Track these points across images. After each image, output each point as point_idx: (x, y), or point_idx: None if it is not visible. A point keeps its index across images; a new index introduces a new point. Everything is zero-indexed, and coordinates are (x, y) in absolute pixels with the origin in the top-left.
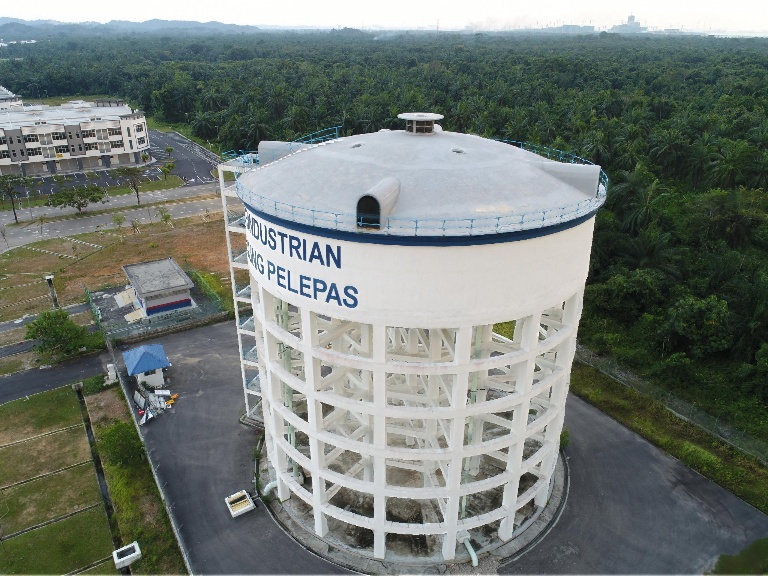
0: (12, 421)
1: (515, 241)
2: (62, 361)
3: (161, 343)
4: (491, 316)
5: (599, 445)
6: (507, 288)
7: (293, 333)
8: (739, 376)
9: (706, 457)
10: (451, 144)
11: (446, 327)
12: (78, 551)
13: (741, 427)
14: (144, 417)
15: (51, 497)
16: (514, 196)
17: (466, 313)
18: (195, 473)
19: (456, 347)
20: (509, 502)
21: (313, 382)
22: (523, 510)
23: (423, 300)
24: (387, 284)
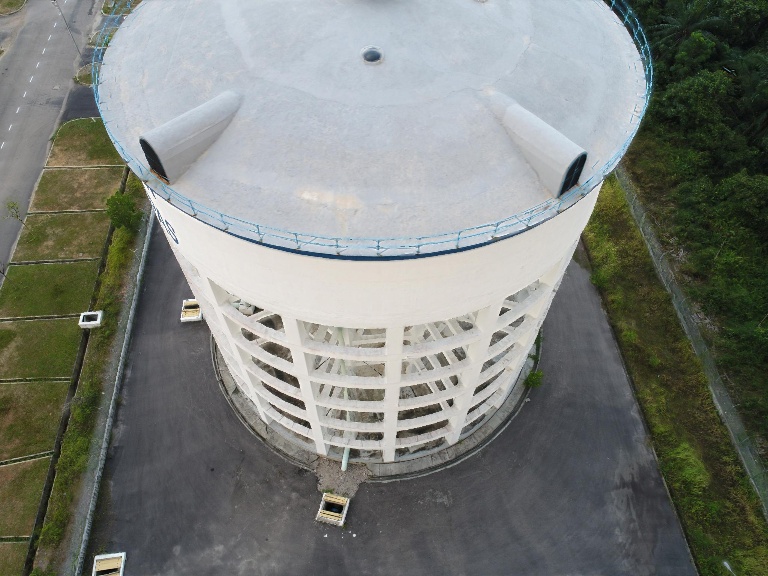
0: (74, 142)
1: (337, 259)
2: None
3: None
4: (318, 318)
5: (578, 399)
6: (338, 299)
7: None
8: None
9: (690, 474)
10: (383, 31)
11: (264, 308)
12: (63, 299)
13: None
14: None
15: (68, 236)
16: (383, 180)
17: (285, 306)
18: None
19: None
20: (385, 442)
21: None
22: None
23: (232, 275)
24: (194, 242)
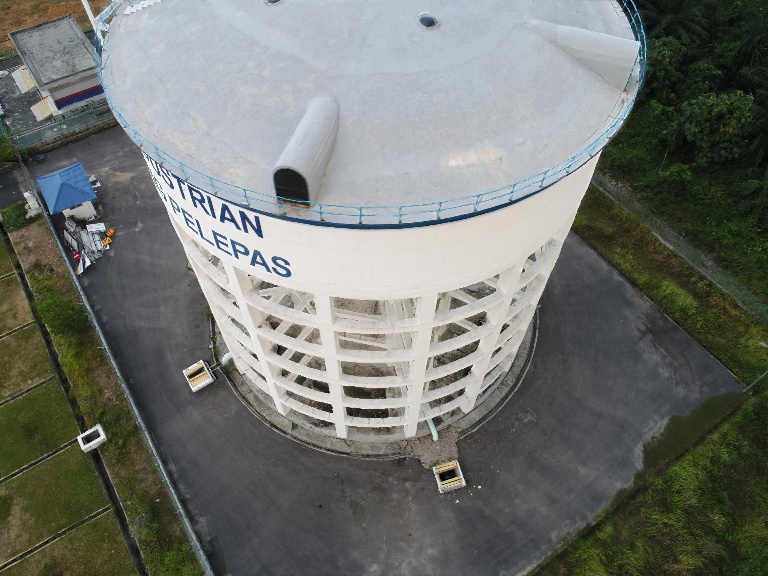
0: None
1: (500, 208)
2: None
3: (83, 150)
4: (462, 281)
5: (574, 287)
6: (485, 252)
7: None
8: (741, 193)
9: (682, 301)
10: None
11: None
12: (42, 435)
13: (726, 258)
14: (81, 263)
15: (1, 371)
16: (506, 124)
17: (430, 284)
18: (147, 338)
19: (418, 306)
20: (472, 392)
21: (251, 321)
22: None
23: (375, 277)
24: (327, 261)
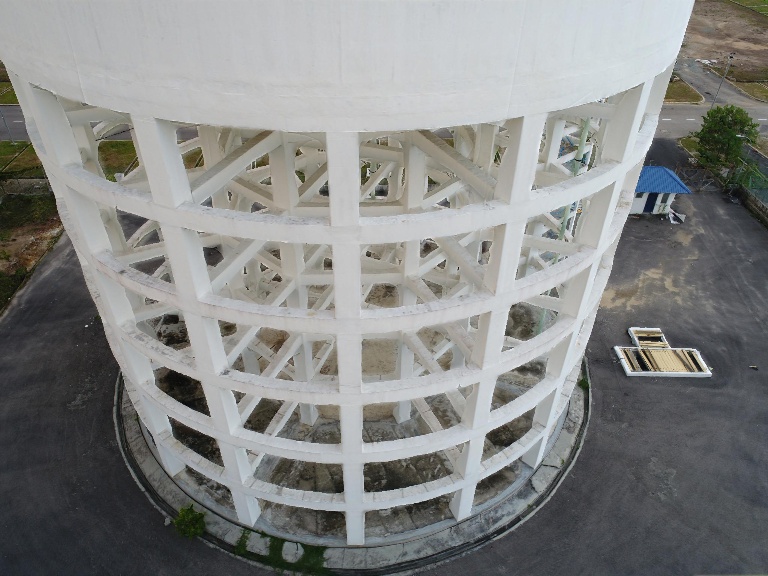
0: None
1: None
2: (703, 167)
3: (742, 224)
4: None
5: None
6: None
7: (767, 344)
8: None
9: None
10: None
11: None
12: None
13: None
14: None
15: None
16: None
17: None
18: None
19: None
20: None
21: None
22: (157, 384)
23: None
24: None
